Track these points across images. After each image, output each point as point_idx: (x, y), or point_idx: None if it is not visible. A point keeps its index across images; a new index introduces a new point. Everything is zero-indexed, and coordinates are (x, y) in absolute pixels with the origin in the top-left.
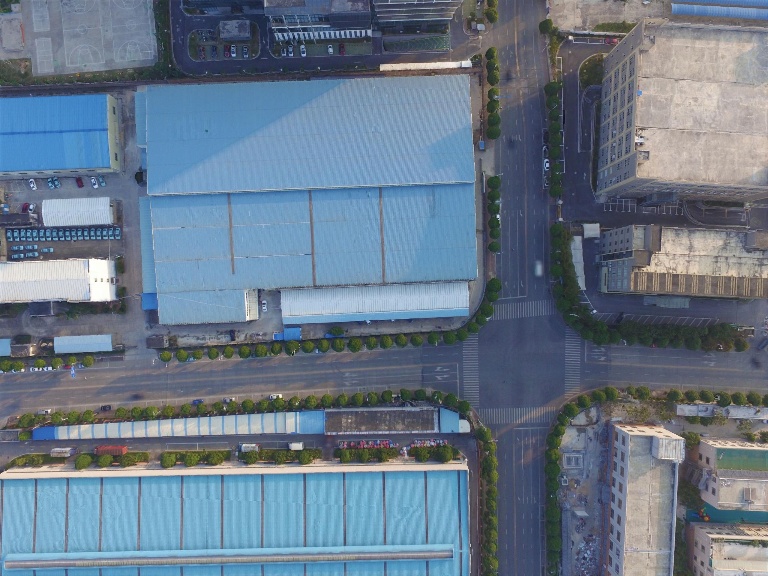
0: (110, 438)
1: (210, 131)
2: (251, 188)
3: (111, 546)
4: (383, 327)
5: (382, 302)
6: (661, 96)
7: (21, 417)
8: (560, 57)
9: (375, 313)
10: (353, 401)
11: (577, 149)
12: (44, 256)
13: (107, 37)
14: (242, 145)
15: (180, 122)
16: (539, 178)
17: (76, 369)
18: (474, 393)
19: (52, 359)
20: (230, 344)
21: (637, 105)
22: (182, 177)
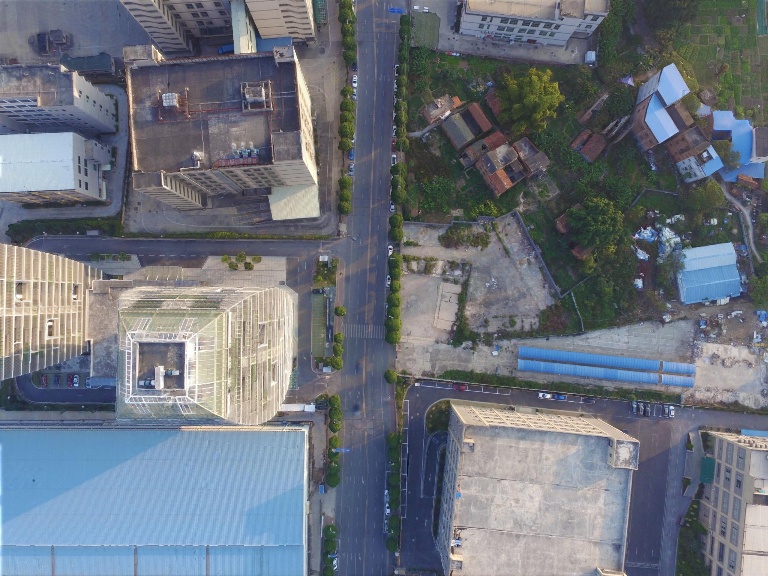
0: None
1: (37, 481)
2: (74, 544)
3: None
4: None
5: None
6: (482, 496)
7: None
8: (407, 400)
9: None
10: None
11: (420, 494)
12: None
13: None
14: (68, 497)
15: (8, 469)
16: (380, 521)
17: None
18: None
19: None
20: None
21: (457, 505)
22: (4, 529)
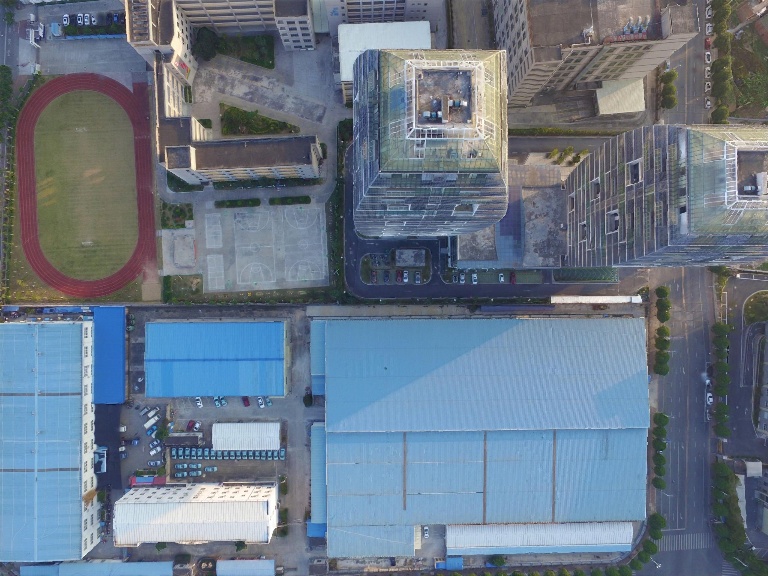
0: None
1: (389, 368)
2: (429, 429)
3: None
4: (542, 555)
5: (547, 537)
6: None
7: None
8: (725, 292)
9: (539, 547)
10: None
11: (739, 384)
12: (207, 474)
13: (279, 256)
14: (421, 384)
15: (359, 358)
16: (701, 411)
17: None
18: None
19: None
20: (391, 571)
21: None
22: (361, 415)
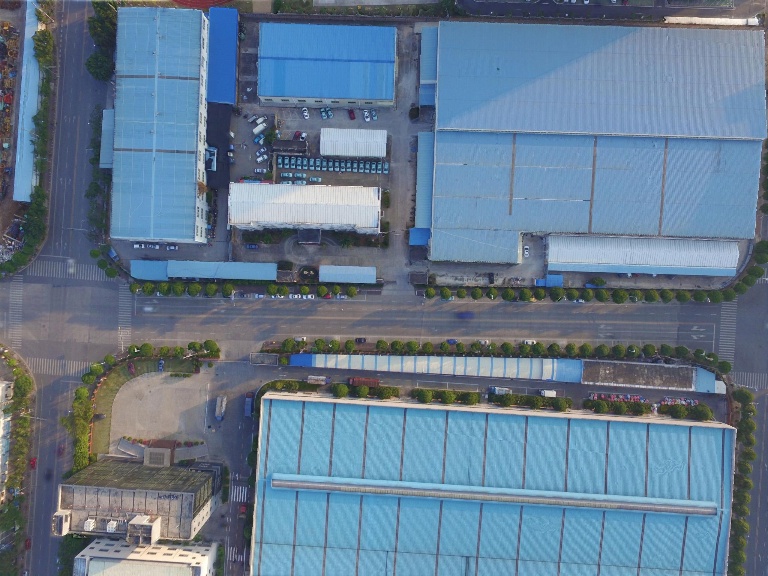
0: (366, 370)
1: (501, 69)
2: (540, 129)
3: (374, 474)
4: (642, 282)
5: (651, 255)
6: None
7: (285, 341)
8: None
9: (642, 266)
10: (616, 352)
11: None
12: None
13: None
14: (533, 86)
15: (472, 58)
16: None
17: (333, 299)
18: (729, 355)
19: (318, 286)
20: (491, 286)
21: None
22: (472, 113)
